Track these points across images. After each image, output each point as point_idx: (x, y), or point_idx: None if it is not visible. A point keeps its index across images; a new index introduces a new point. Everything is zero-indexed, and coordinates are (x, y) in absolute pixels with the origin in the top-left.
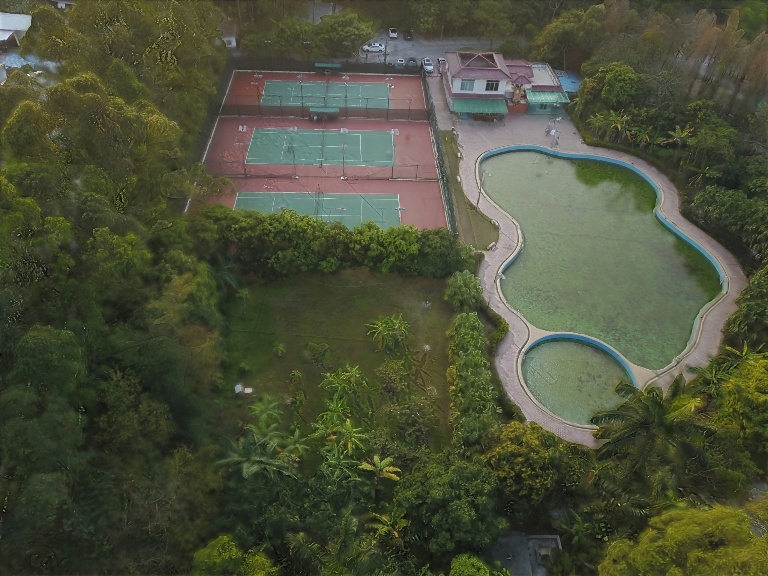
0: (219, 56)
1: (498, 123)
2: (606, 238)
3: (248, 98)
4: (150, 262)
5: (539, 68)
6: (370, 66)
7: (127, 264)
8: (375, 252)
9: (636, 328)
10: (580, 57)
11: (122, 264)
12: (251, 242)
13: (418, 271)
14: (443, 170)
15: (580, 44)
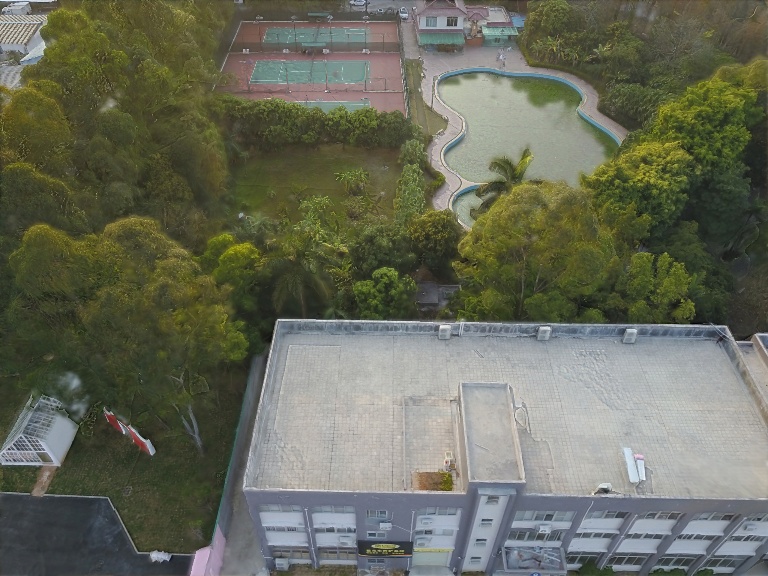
0: (227, 2)
1: (458, 53)
2: (534, 128)
3: (252, 36)
4: None
5: (496, 11)
6: (354, 14)
7: (163, 82)
8: (344, 127)
9: None
10: None
11: (160, 81)
12: (250, 118)
13: (378, 142)
14: (408, 85)
15: None
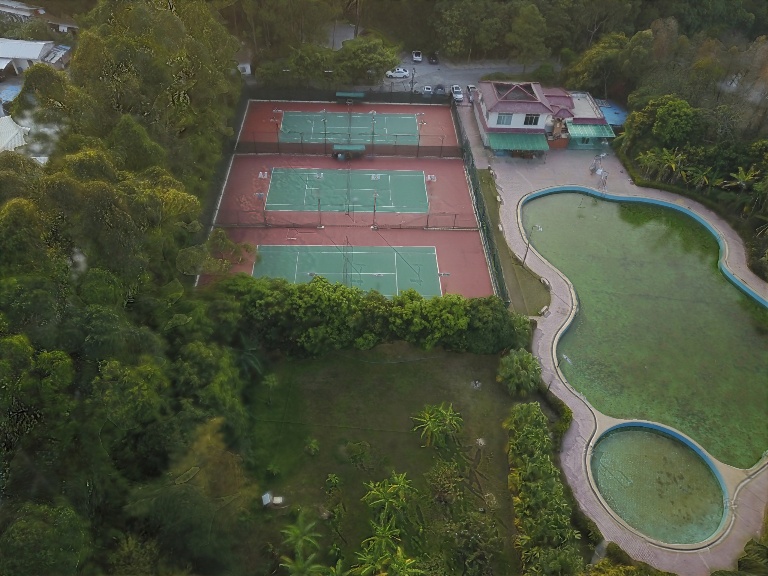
0: (235, 90)
1: (537, 160)
2: (669, 298)
3: (266, 135)
4: (165, 357)
5: (578, 97)
6: (395, 95)
7: (142, 408)
8: (418, 327)
9: (715, 412)
10: (624, 86)
11: (135, 408)
12: (278, 319)
13: (467, 348)
14: None
15: (625, 72)
